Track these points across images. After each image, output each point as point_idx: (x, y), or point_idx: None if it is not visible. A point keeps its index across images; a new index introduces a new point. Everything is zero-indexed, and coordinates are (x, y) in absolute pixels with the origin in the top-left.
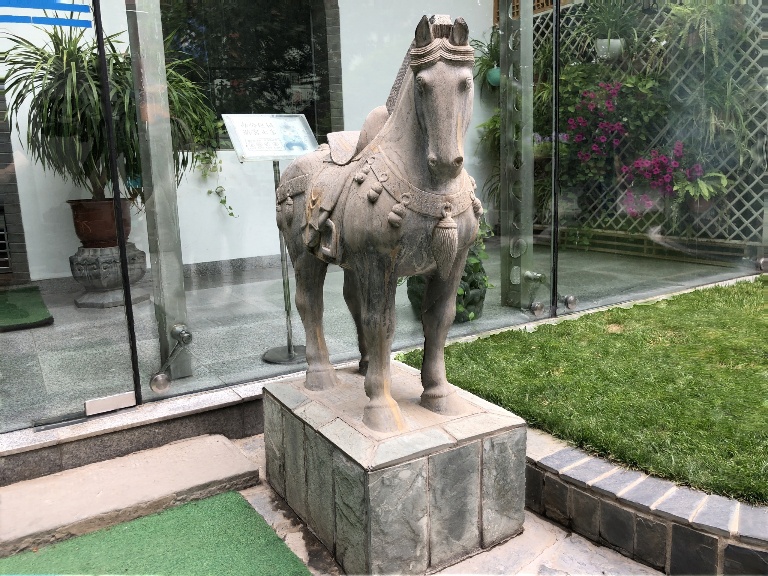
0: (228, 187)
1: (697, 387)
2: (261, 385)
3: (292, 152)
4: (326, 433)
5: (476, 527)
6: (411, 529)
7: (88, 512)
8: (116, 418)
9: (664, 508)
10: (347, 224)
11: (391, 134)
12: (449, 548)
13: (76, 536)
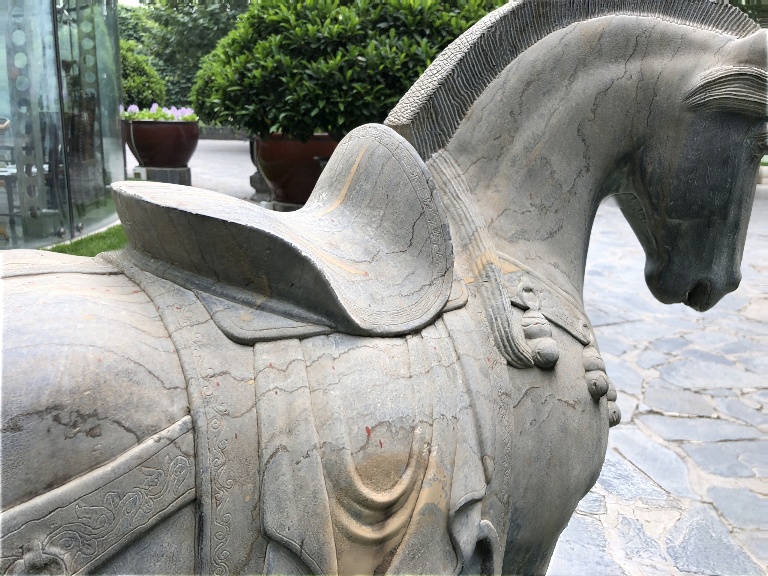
0: None
1: None
2: None
3: None
4: None
5: None
6: None
7: None
8: None
9: None
10: (546, 492)
11: (521, 221)
12: None
13: None
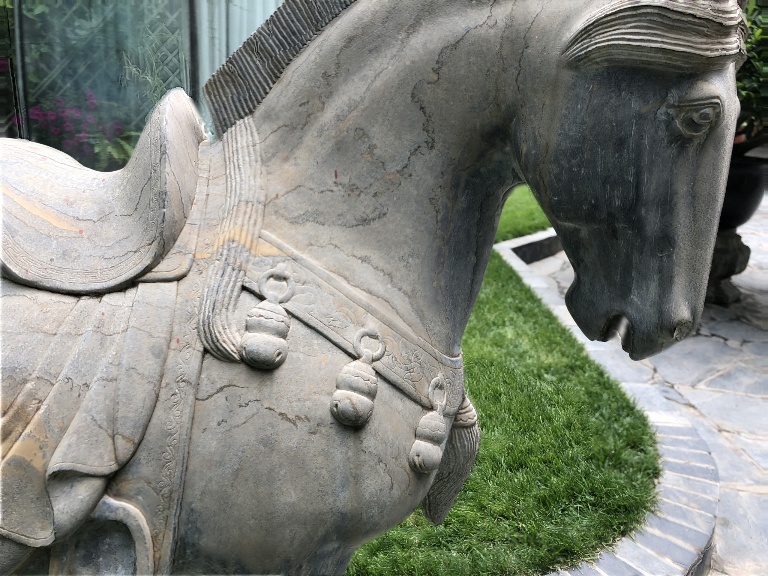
0: None
1: None
2: None
3: None
4: None
5: None
6: None
7: None
8: None
9: None
10: (230, 506)
11: (315, 201)
12: None
13: None
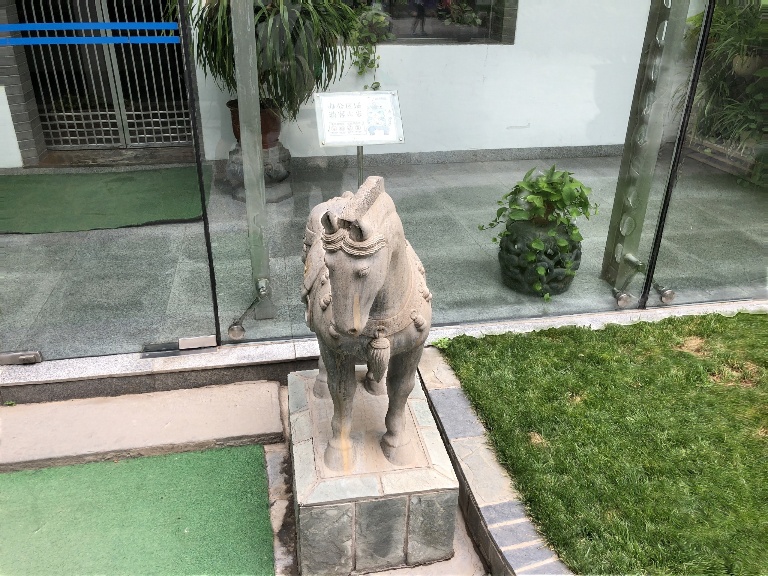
0: (315, 161)
1: (700, 460)
2: (317, 345)
3: (372, 137)
4: (295, 453)
5: (402, 551)
6: (336, 547)
7: (153, 441)
8: (197, 357)
9: None
10: None
11: None
12: (374, 561)
13: (144, 456)
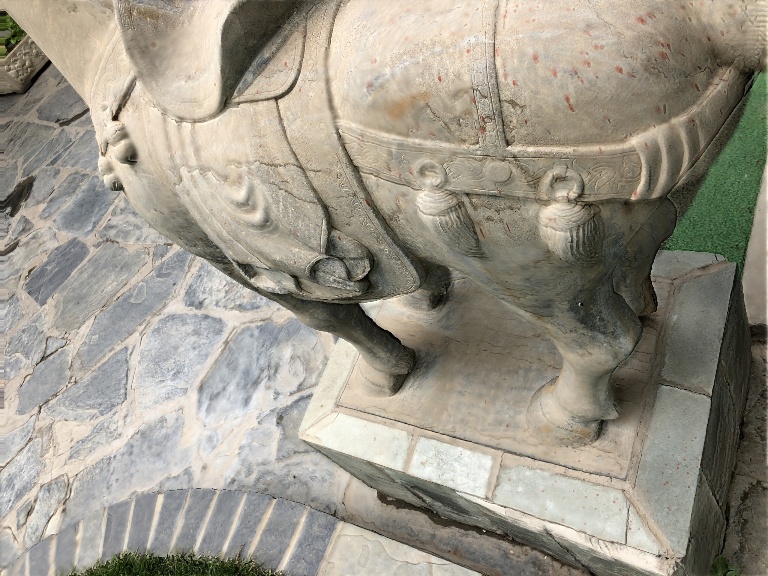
0: None
1: None
2: None
3: None
4: None
5: None
6: None
7: None
8: None
9: (208, 494)
10: None
11: None
12: None
13: None
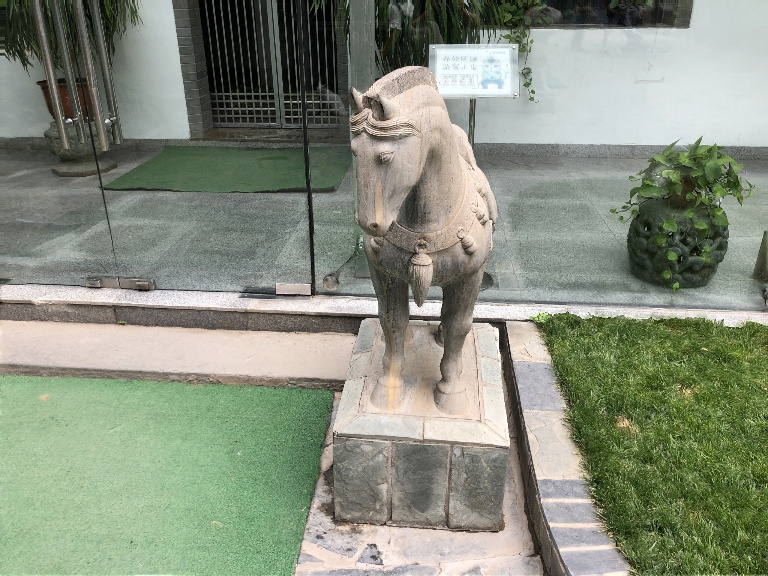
0: None
1: None
2: None
3: (485, 91)
4: (345, 387)
5: (443, 509)
6: (371, 488)
7: (232, 371)
8: (290, 302)
9: None
10: None
11: None
12: (411, 514)
13: (222, 384)
